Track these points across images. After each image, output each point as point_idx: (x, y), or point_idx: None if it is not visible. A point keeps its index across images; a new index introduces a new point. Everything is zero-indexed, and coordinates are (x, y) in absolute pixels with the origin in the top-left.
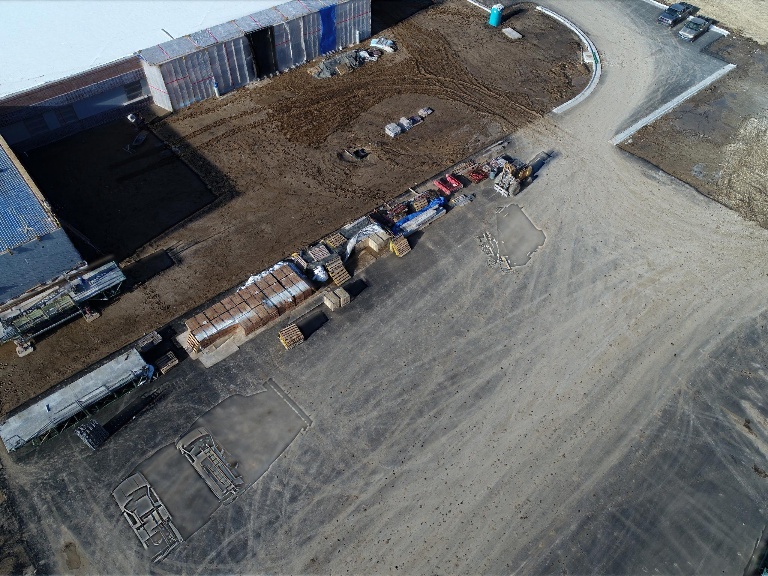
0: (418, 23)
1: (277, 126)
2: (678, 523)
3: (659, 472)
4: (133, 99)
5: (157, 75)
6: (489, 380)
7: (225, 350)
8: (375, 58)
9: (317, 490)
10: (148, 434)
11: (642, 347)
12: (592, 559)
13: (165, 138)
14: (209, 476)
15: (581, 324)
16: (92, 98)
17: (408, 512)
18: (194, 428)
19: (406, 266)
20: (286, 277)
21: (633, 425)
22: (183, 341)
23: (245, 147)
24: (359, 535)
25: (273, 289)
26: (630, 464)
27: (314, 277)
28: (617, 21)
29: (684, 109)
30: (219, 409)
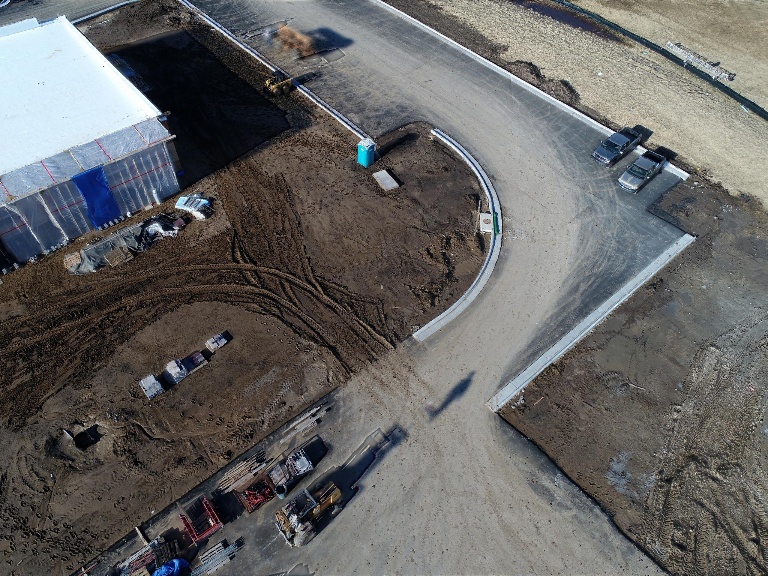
0: (258, 163)
1: None
2: None
3: None
4: None
5: None
6: None
7: None
8: (174, 232)
9: None
10: None
11: None
12: None
13: None
14: None
15: None
16: None
17: None
18: None
19: None
20: None
21: None
22: None
23: None
24: None
25: None
26: None
27: None
28: (537, 155)
29: (612, 327)
30: None
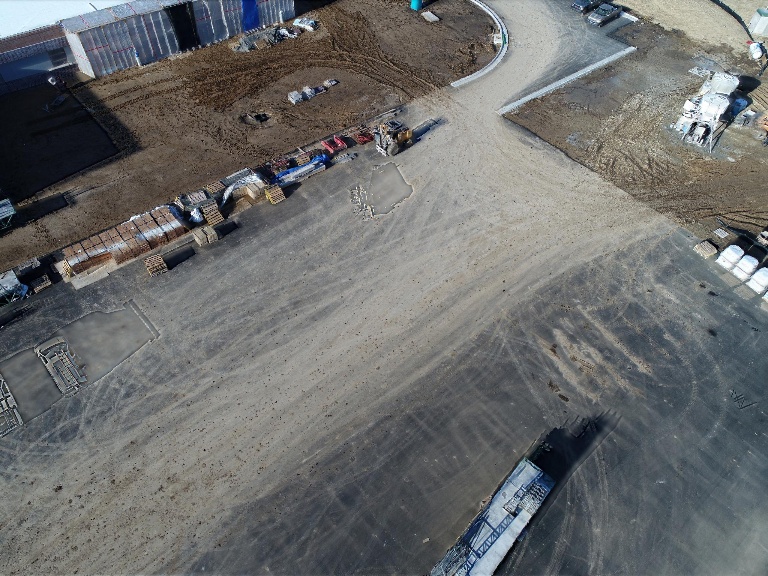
0: (343, 6)
1: (189, 92)
2: (466, 425)
3: (461, 384)
4: (58, 66)
5: (77, 43)
6: (327, 306)
7: (96, 276)
8: (295, 36)
9: (150, 388)
10: (12, 340)
11: (475, 283)
12: (380, 450)
13: (83, 100)
14: (58, 375)
15: (424, 263)
16: (17, 62)
17: (226, 408)
18: (53, 337)
19: (278, 212)
20: (162, 216)
21: (448, 346)
22: (60, 267)
23: (155, 109)
24: (178, 424)
25: (148, 226)
26: (436, 377)
27: (190, 218)
28: (534, 7)
29: (576, 85)
30: (79, 322)
